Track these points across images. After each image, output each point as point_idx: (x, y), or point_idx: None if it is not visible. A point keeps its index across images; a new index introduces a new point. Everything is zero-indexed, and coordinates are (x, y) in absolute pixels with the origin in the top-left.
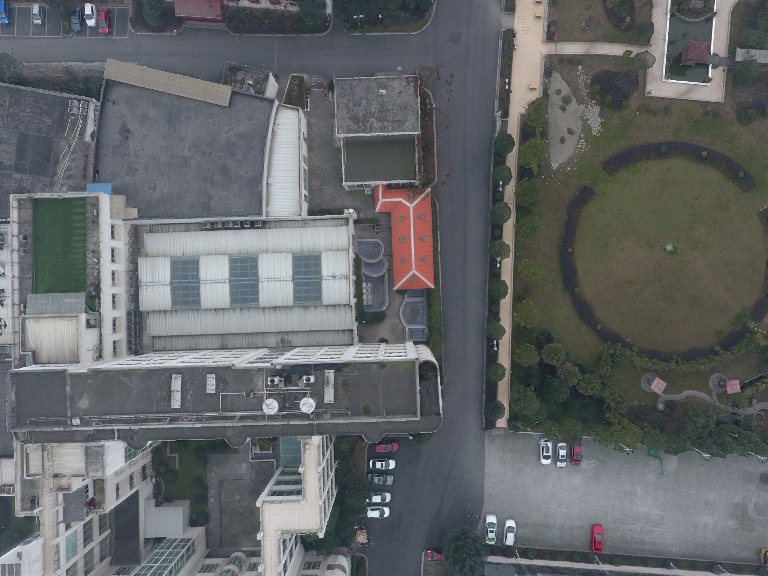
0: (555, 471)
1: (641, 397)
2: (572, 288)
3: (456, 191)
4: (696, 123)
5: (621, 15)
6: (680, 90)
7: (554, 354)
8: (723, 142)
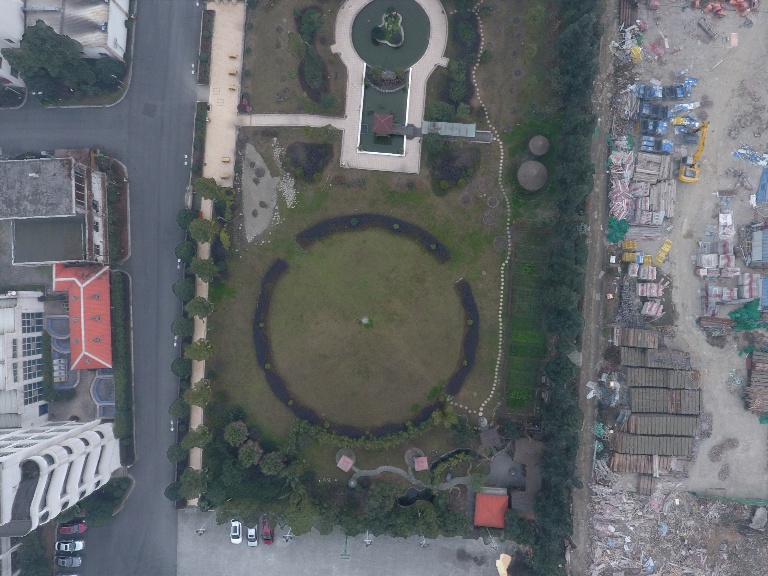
0: (249, 550)
1: (336, 473)
2: (263, 364)
3: (150, 265)
4: (392, 194)
5: (314, 87)
6: (376, 161)
7: (228, 435)
8: (419, 213)
